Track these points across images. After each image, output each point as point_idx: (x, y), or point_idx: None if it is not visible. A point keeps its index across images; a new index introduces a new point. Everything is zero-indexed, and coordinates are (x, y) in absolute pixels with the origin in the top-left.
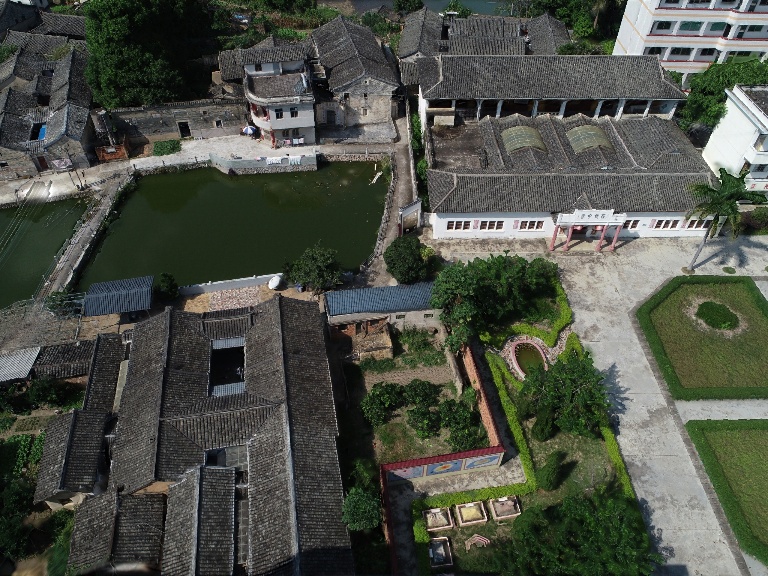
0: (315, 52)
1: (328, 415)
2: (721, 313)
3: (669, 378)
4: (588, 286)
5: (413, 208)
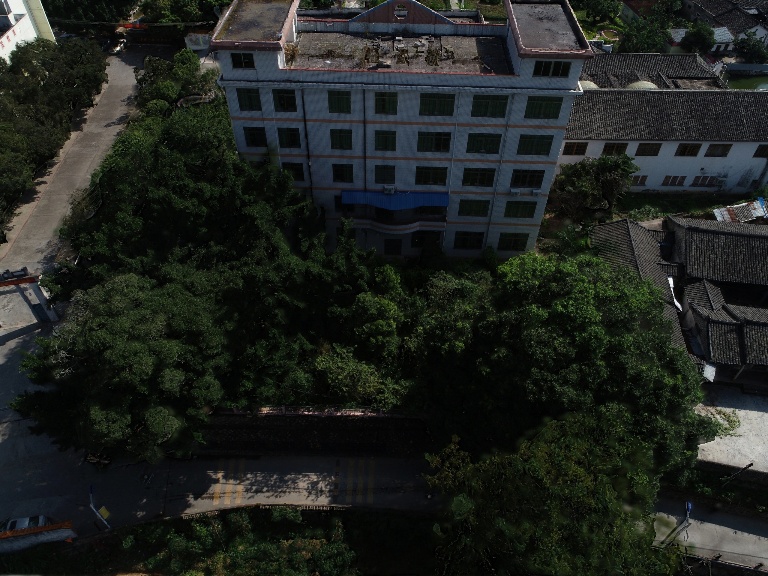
0: None
1: (701, 3)
2: None
3: None
4: None
5: (714, 68)
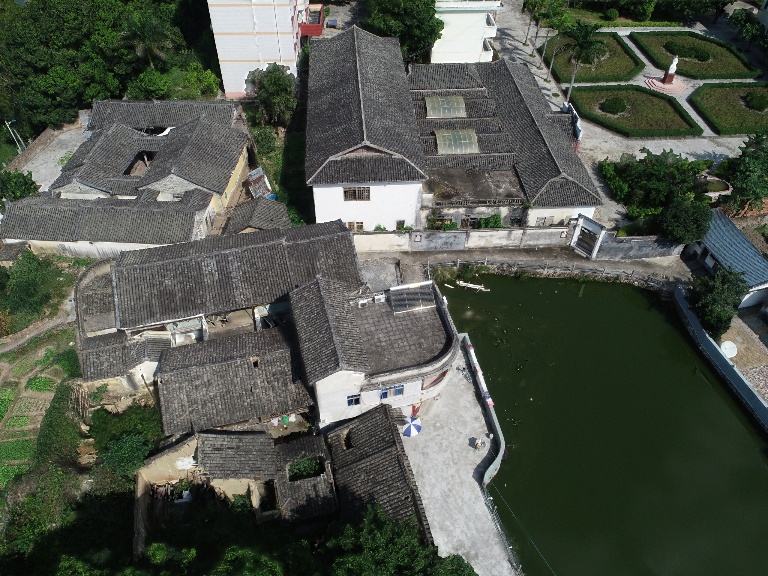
0: (159, 340)
1: None
2: (617, 102)
3: (691, 131)
4: (608, 153)
5: None
